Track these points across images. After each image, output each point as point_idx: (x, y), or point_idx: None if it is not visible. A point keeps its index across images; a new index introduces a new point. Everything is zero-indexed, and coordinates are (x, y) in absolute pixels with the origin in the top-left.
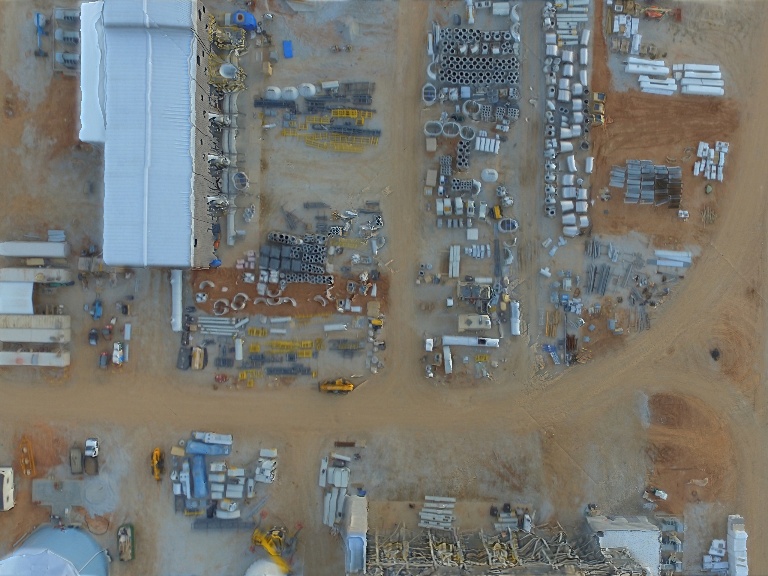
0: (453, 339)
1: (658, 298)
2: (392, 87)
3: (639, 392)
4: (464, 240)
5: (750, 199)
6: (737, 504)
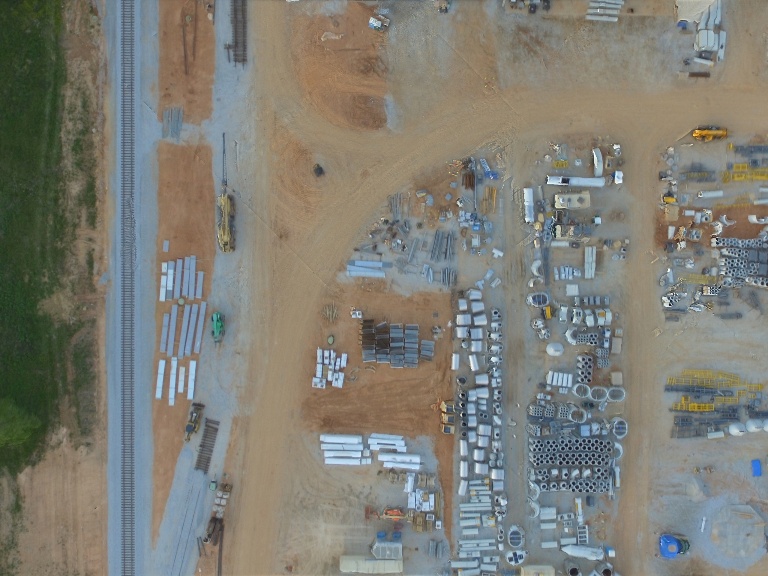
0: (594, 183)
1: (380, 228)
2: (654, 434)
3: (397, 131)
4: (581, 284)
5: (288, 331)
6: (291, 13)
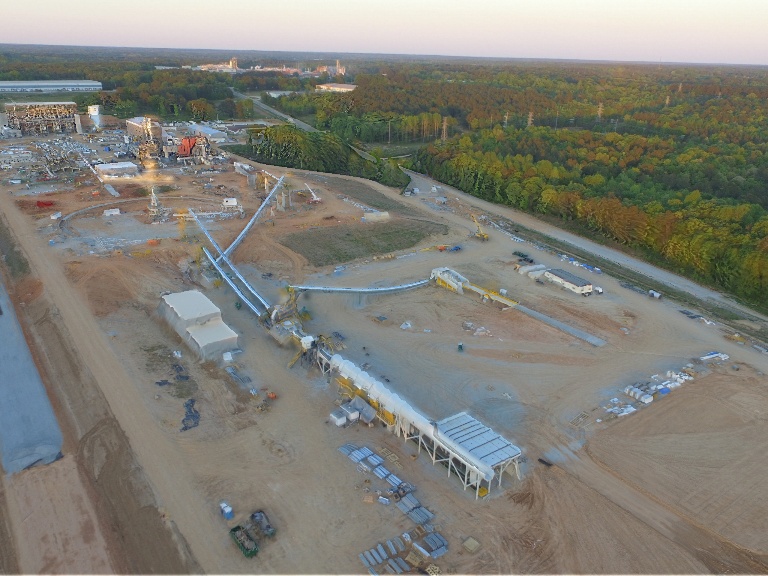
0: None
1: None
2: None
3: None
4: None
5: None
6: None
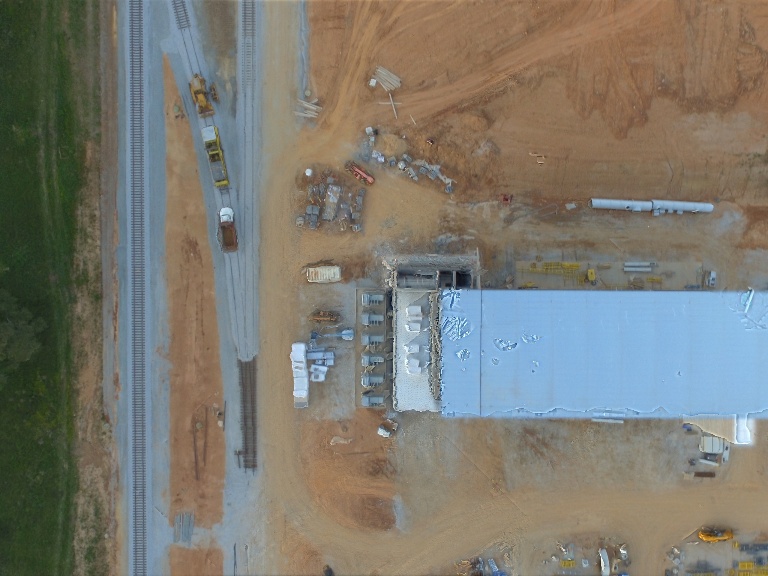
0: None
1: None
2: None
3: (406, 531)
4: None
5: None
6: (300, 418)
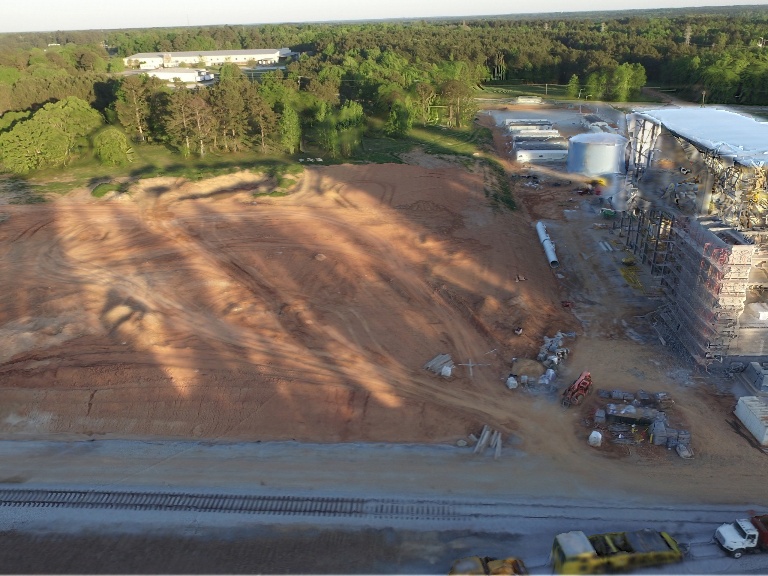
0: None
1: None
2: None
3: None
4: None
5: None
6: None
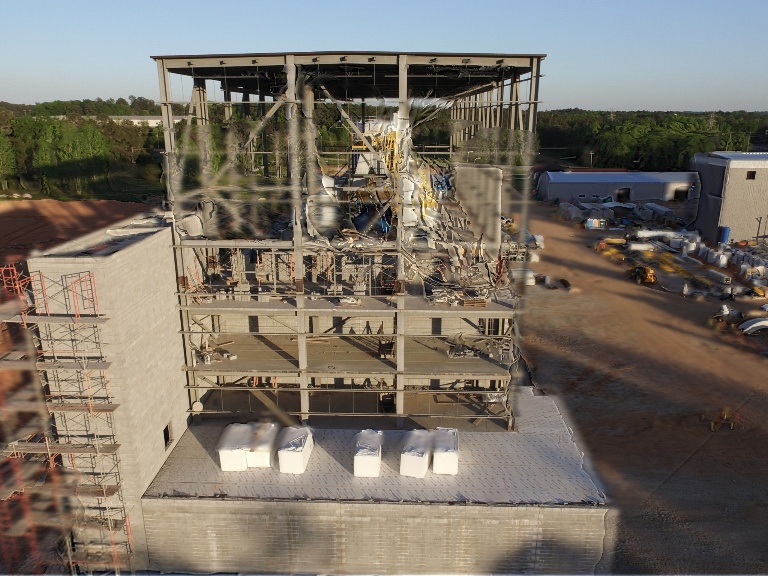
0: None
1: None
2: None
3: None
4: None
5: None
6: None
